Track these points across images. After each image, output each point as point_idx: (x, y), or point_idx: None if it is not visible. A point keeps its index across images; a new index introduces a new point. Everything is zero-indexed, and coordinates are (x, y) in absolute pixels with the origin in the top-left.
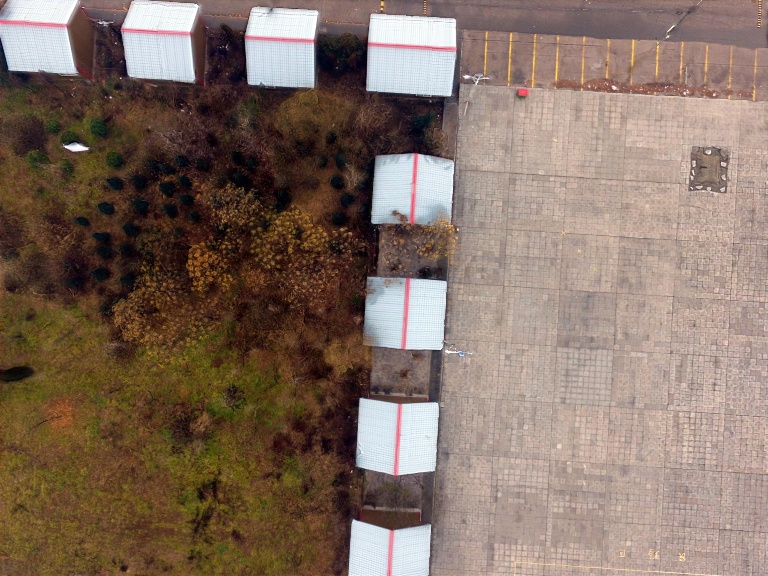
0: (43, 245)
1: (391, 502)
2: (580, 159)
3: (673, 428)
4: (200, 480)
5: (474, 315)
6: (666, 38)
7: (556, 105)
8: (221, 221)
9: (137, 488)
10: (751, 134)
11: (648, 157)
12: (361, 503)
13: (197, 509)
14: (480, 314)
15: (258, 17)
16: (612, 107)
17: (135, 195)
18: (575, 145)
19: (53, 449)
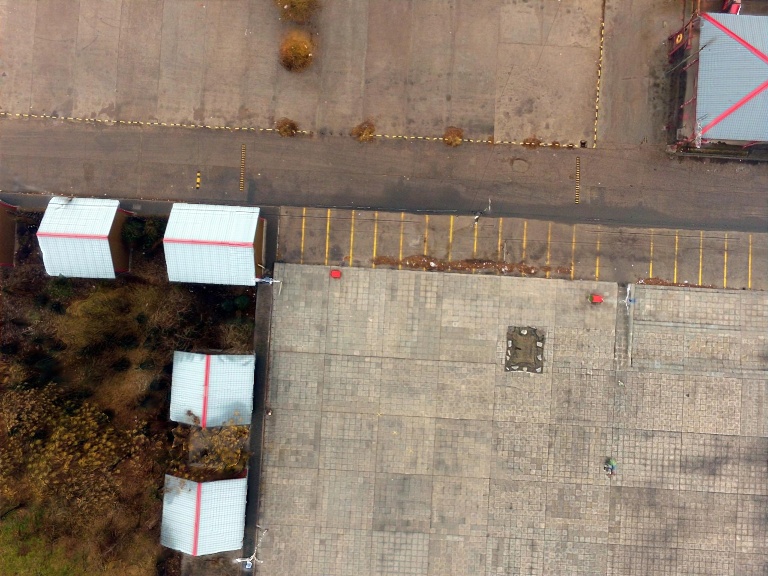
0: None
1: None
2: (396, 339)
3: None
4: None
5: (288, 499)
6: None
7: (371, 285)
8: (7, 426)
9: None
10: (567, 314)
11: (464, 337)
12: None
13: None
14: (294, 498)
15: (55, 210)
16: (428, 286)
17: None
18: (391, 325)
19: None
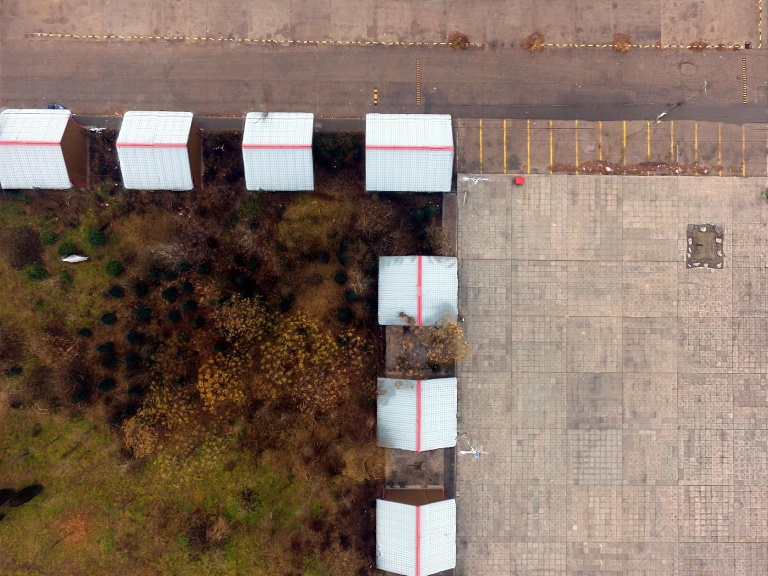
0: (46, 358)
1: None
2: (579, 242)
3: (685, 502)
4: None
5: (484, 403)
6: None
7: (553, 190)
8: (228, 334)
9: None
10: (743, 210)
11: (645, 237)
12: None
13: None
14: (490, 401)
15: (254, 124)
16: (608, 190)
17: (137, 302)
18: (574, 229)
19: (67, 565)
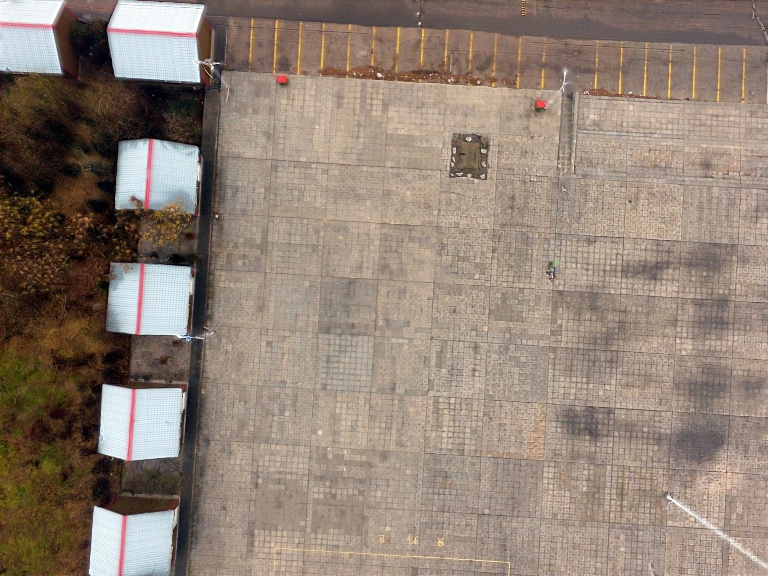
0: None
1: (150, 489)
2: (342, 146)
3: (433, 414)
4: None
5: (235, 302)
6: (418, 25)
7: (318, 92)
8: None
9: None
10: (511, 121)
11: (409, 144)
12: (120, 490)
13: None
14: (241, 301)
15: (1, 2)
16: (374, 94)
17: None
18: (337, 132)
19: None
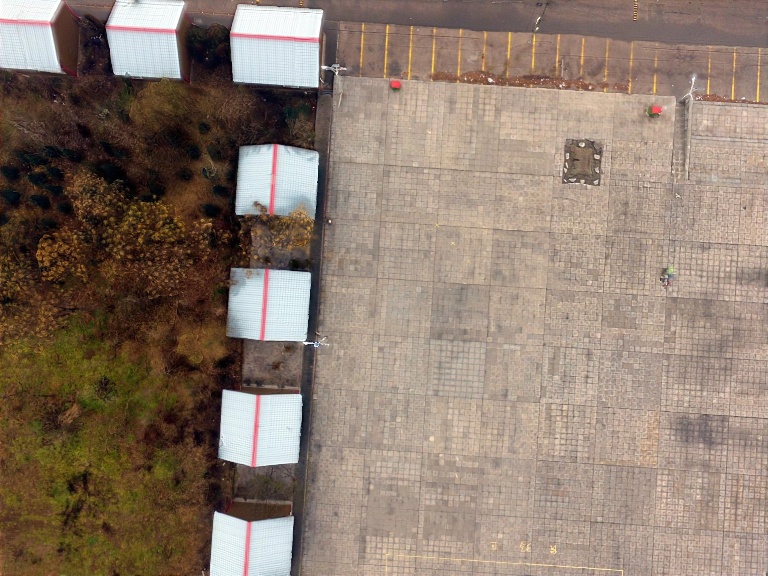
0: None
1: (262, 494)
2: (454, 151)
3: (545, 420)
4: (70, 472)
5: (347, 307)
6: (536, 30)
7: (430, 97)
8: (79, 211)
9: (6, 480)
10: (624, 127)
11: (522, 149)
12: (232, 495)
13: (67, 501)
14: (353, 306)
15: (122, 7)
16: (486, 99)
17: (7, 186)
18: (449, 137)
19: None
